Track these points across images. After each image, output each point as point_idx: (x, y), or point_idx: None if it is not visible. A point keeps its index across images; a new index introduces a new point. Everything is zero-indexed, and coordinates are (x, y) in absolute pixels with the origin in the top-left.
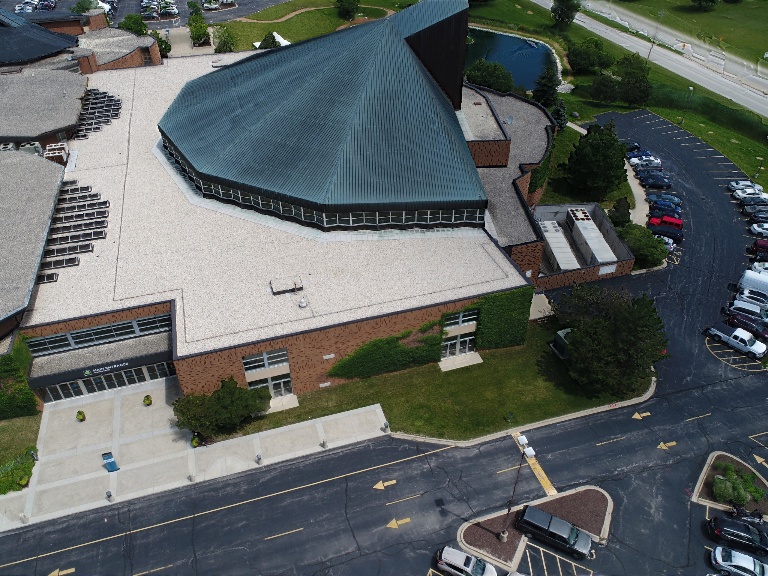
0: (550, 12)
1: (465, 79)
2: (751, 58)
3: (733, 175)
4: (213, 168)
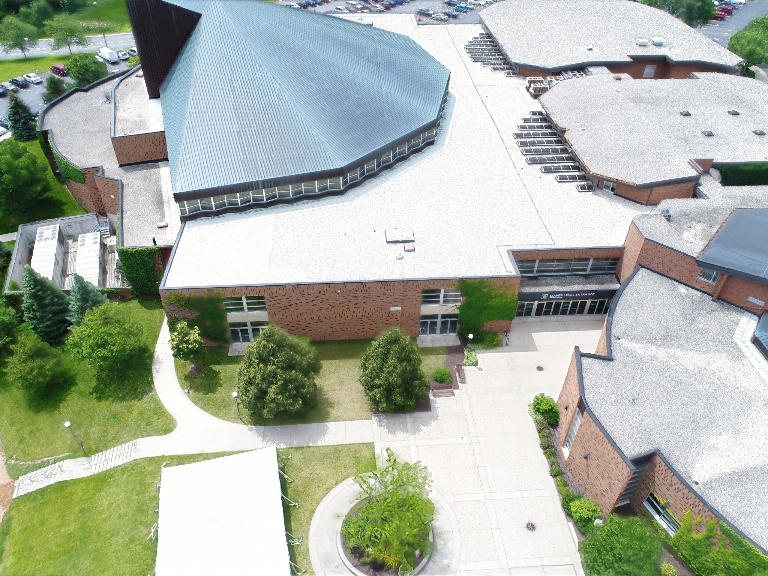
0: None
1: None
2: None
3: None
4: None
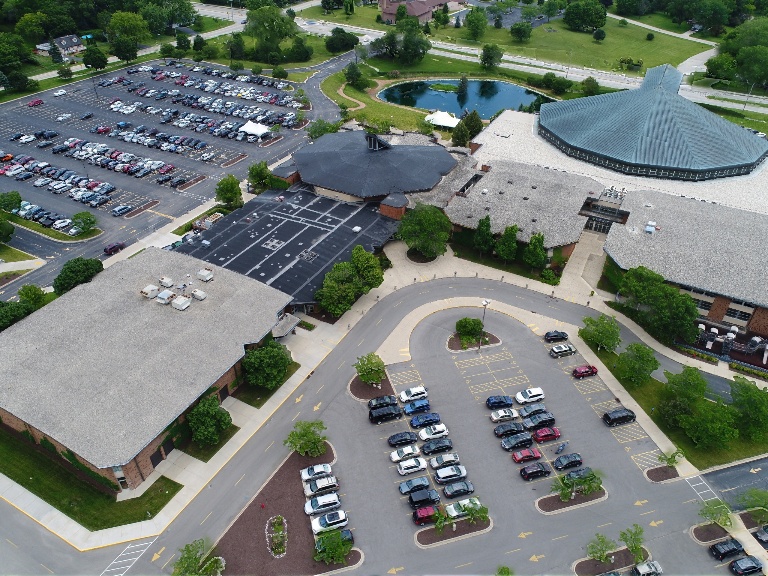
0: (461, 60)
1: None
2: (643, 69)
3: None
4: (703, 166)
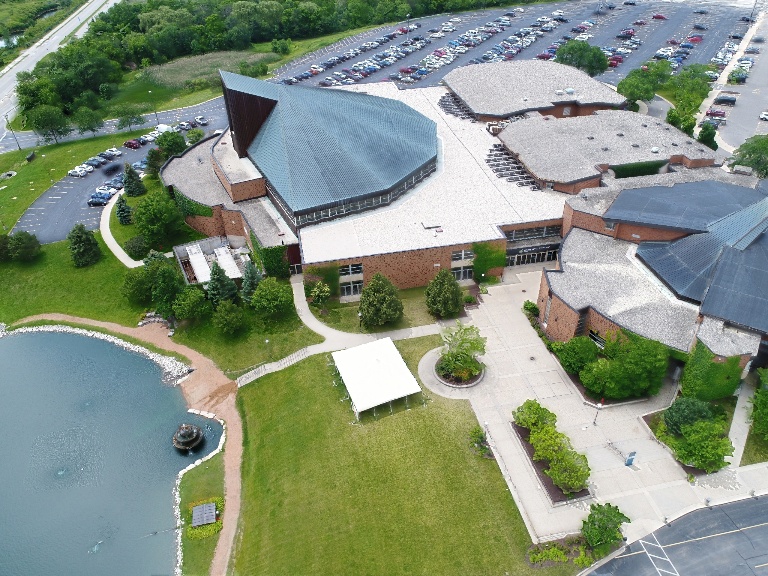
0: None
1: None
2: None
3: (64, 183)
4: None
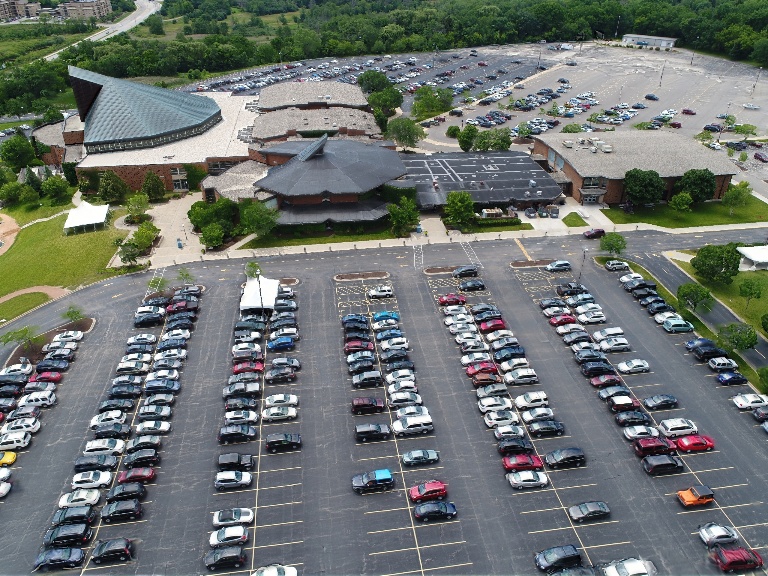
0: None
1: (7, 167)
2: None
3: None
4: None
